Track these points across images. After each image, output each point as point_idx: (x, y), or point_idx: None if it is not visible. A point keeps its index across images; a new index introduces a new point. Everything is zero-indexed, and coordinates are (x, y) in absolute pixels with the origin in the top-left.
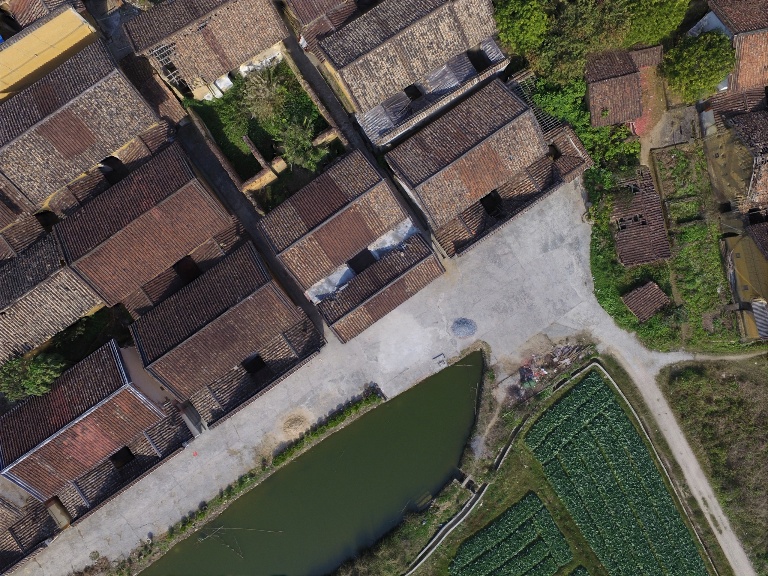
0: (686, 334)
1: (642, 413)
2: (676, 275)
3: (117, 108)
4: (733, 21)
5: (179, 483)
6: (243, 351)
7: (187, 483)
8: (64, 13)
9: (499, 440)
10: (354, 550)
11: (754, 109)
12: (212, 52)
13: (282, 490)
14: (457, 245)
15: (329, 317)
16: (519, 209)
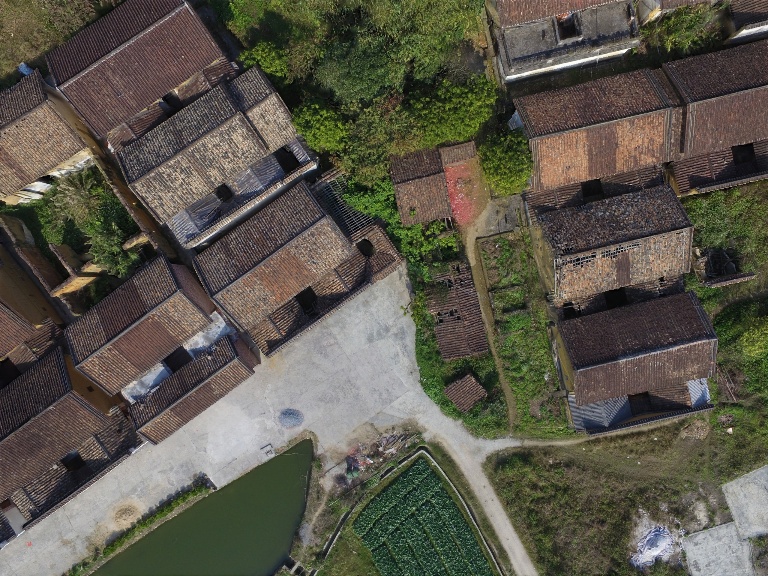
0: (514, 421)
1: (469, 500)
2: (503, 363)
3: None
4: (531, 123)
5: (15, 572)
6: (53, 455)
7: (23, 572)
8: None
9: (326, 528)
10: None
11: (566, 204)
12: (7, 167)
13: (119, 575)
14: (270, 344)
15: (137, 421)
16: (327, 310)
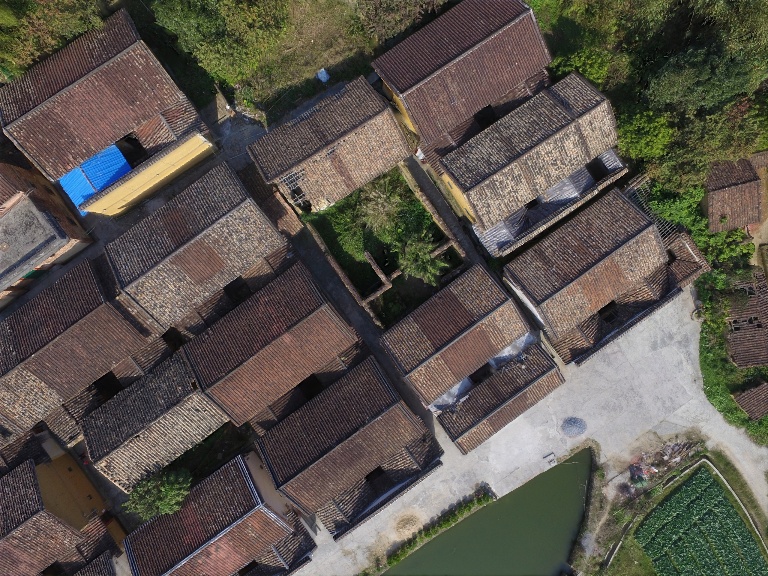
0: None
1: (752, 509)
2: None
3: (246, 234)
4: None
5: None
6: (368, 466)
7: None
8: (191, 139)
9: (610, 538)
10: None
11: None
12: (338, 175)
13: None
14: (574, 353)
15: (452, 431)
16: (638, 318)
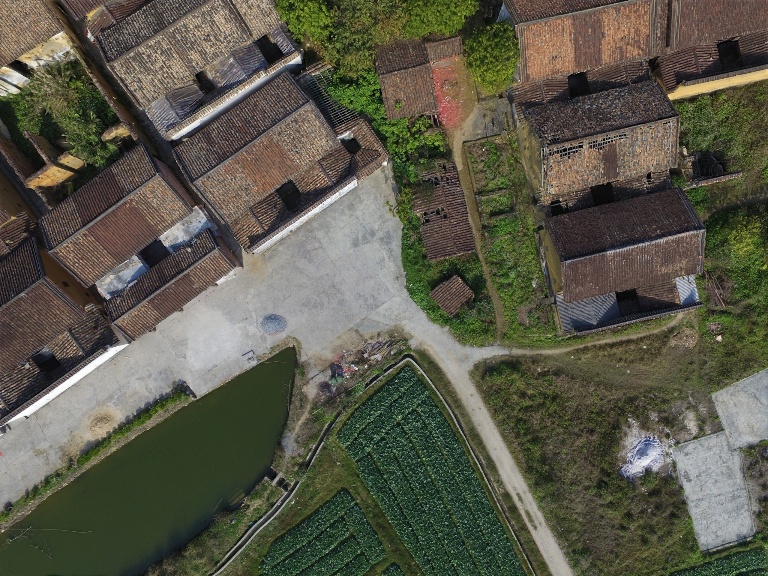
0: (501, 328)
1: (455, 408)
2: (490, 269)
3: None
4: (518, 11)
5: None
6: (25, 349)
7: None
8: None
9: (309, 437)
10: (166, 550)
11: (553, 100)
12: None
13: (93, 490)
14: (252, 240)
15: (113, 314)
16: (310, 203)
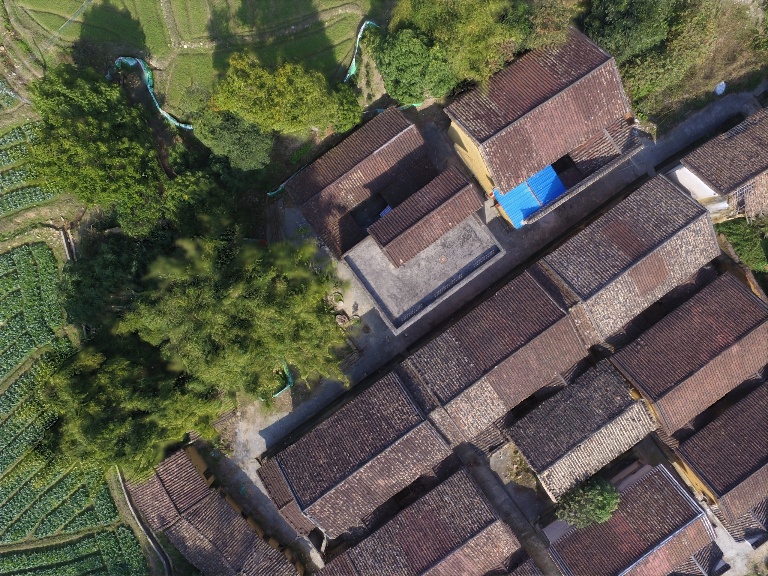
0: None
1: None
2: None
3: (694, 246)
4: None
5: None
6: None
7: None
8: None
9: None
10: None
11: None
12: None
13: None
14: None
15: None
16: None
